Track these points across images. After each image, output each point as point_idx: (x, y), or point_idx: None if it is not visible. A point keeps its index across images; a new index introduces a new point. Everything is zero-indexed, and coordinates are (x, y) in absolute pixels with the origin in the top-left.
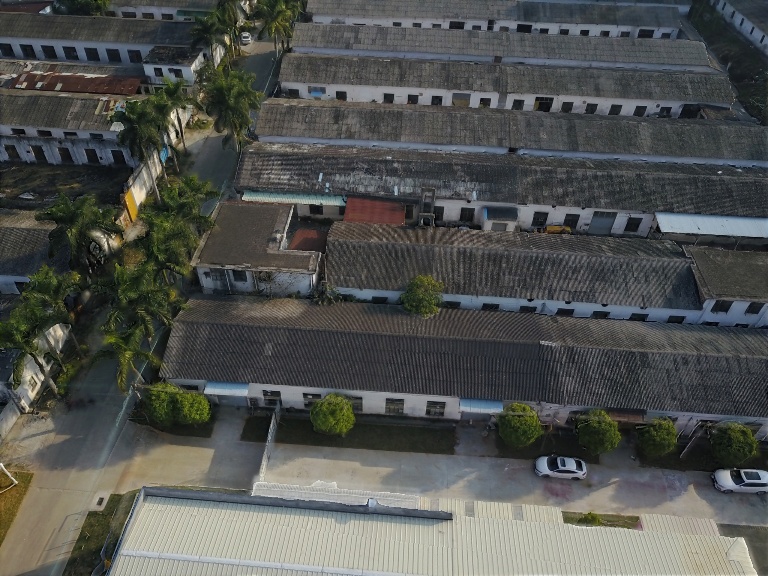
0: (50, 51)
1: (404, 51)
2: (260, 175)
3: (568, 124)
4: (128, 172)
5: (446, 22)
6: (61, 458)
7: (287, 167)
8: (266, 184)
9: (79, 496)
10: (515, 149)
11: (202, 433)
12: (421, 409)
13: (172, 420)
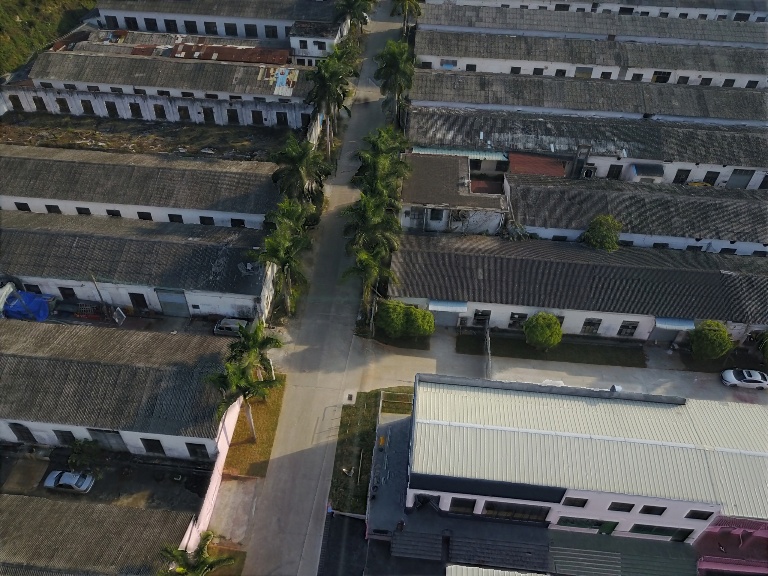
0: (192, 26)
1: (523, 29)
2: (426, 133)
3: (697, 93)
4: (290, 132)
5: (552, 5)
6: (306, 363)
7: (450, 126)
8: (433, 141)
9: (331, 393)
10: (650, 115)
11: (422, 346)
12: (614, 329)
13: (404, 331)
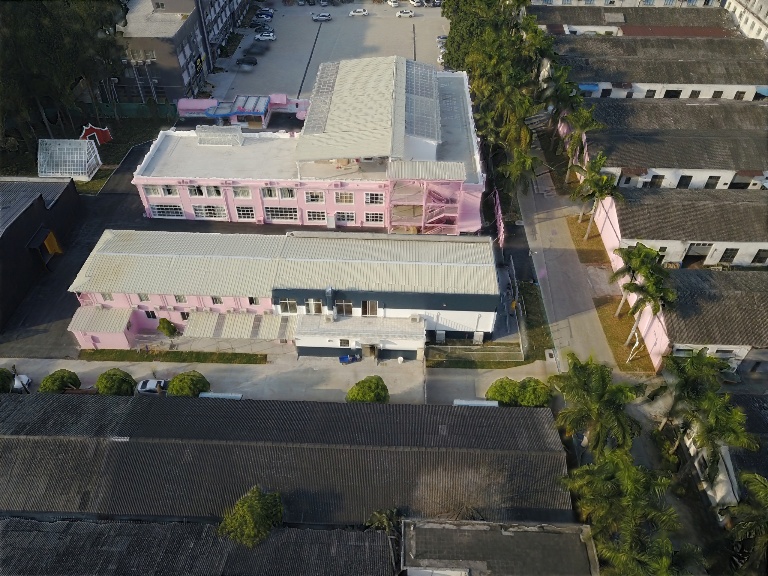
0: None
1: None
2: None
3: None
4: None
5: None
6: None
7: None
8: None
9: None
10: None
11: None
12: None
13: None
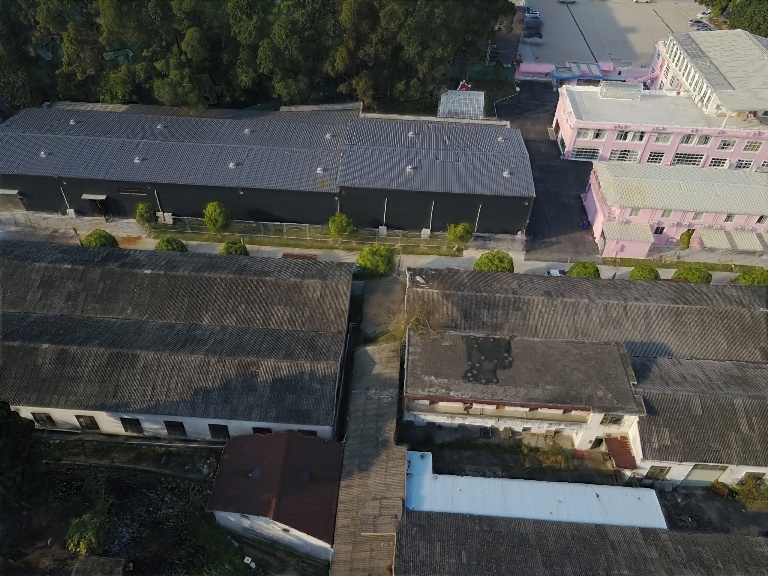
0: None
1: None
2: None
3: None
4: None
5: None
6: None
7: None
8: None
9: None
10: None
11: None
12: None
13: None
